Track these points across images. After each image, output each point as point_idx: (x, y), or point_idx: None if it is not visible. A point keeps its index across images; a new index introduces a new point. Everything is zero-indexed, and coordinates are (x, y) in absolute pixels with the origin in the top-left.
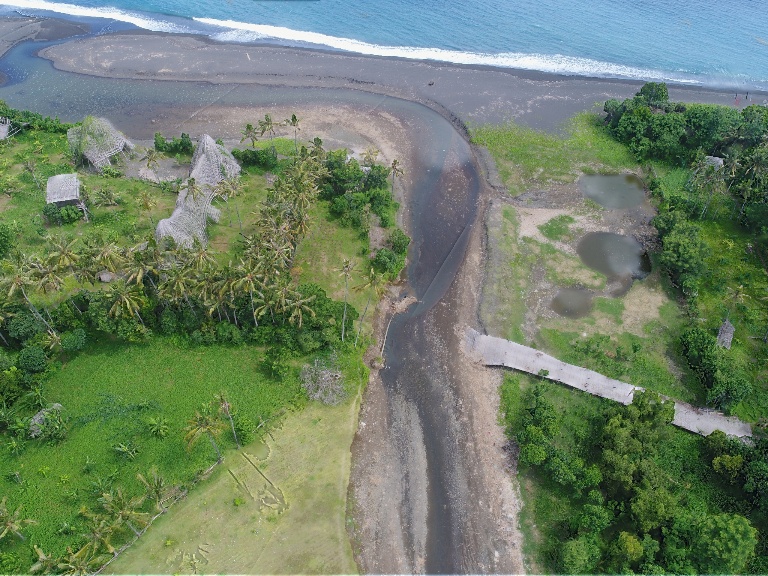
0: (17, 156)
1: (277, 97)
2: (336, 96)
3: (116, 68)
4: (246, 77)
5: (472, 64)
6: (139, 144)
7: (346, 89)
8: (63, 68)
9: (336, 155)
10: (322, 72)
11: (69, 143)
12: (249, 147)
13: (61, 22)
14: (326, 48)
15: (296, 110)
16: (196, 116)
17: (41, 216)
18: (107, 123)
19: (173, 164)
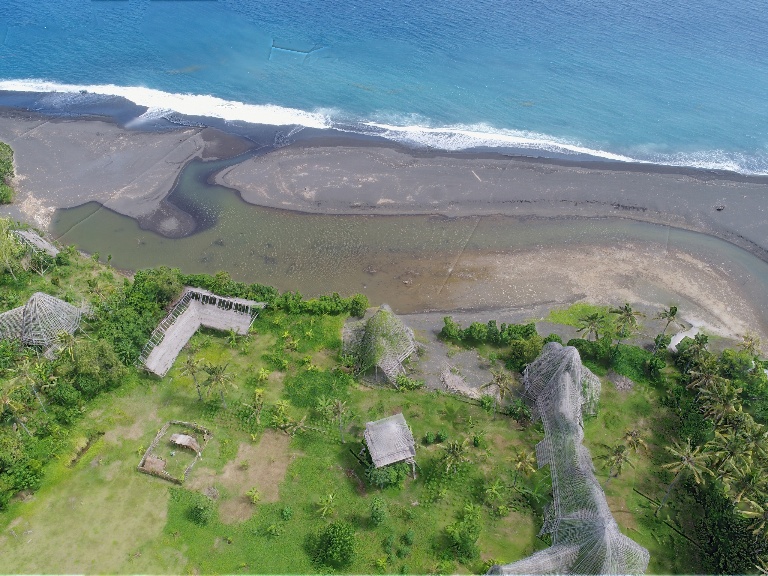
0: (267, 358)
1: (537, 235)
2: (608, 230)
3: (324, 200)
4: (486, 206)
5: (740, 173)
6: (415, 327)
7: (614, 218)
8: (256, 201)
9: (733, 359)
10: (577, 195)
11: (344, 342)
12: (558, 325)
13: (224, 131)
14: (555, 156)
15: (573, 255)
16: (455, 271)
17: (345, 470)
18: (392, 312)
19: (479, 362)
